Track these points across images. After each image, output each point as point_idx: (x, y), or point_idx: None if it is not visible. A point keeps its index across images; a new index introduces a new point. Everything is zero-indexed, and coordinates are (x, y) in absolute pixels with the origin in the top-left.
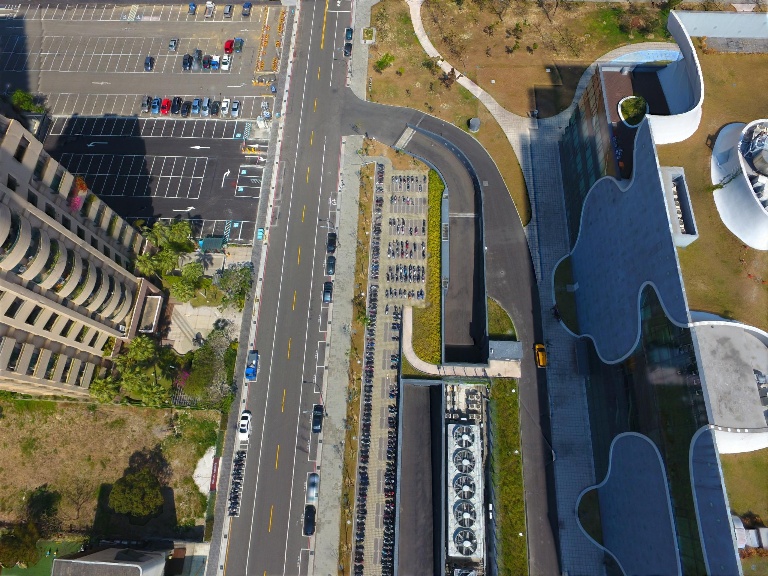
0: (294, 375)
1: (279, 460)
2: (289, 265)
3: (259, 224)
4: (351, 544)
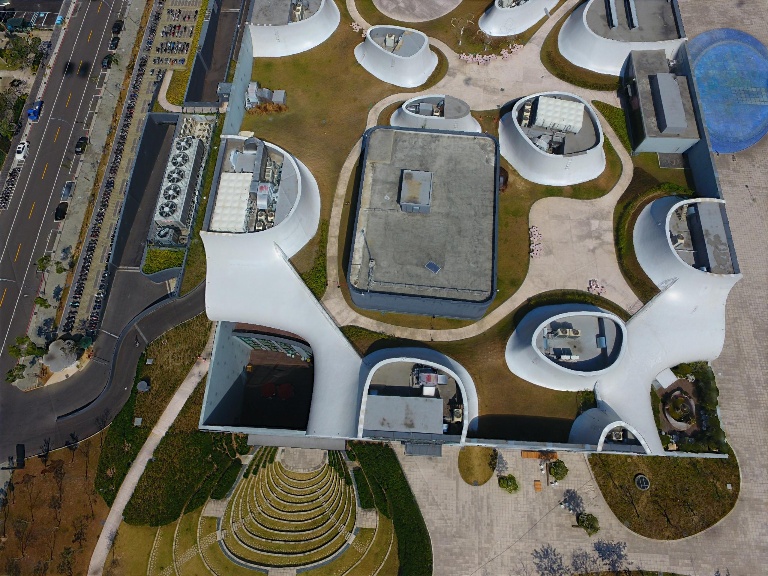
0: (69, 117)
1: (46, 173)
2: (80, 43)
3: (62, 15)
4: (89, 223)
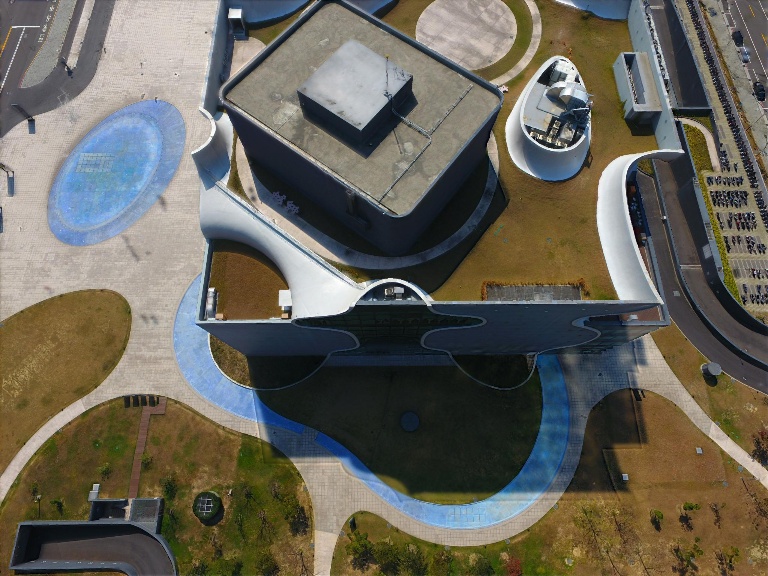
0: None
1: None
2: None
3: None
4: None
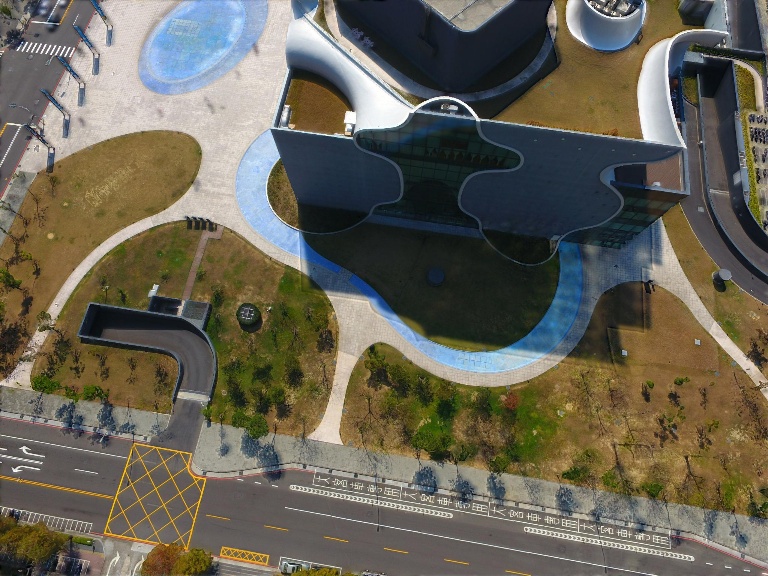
0: None
1: None
2: None
3: None
4: None
